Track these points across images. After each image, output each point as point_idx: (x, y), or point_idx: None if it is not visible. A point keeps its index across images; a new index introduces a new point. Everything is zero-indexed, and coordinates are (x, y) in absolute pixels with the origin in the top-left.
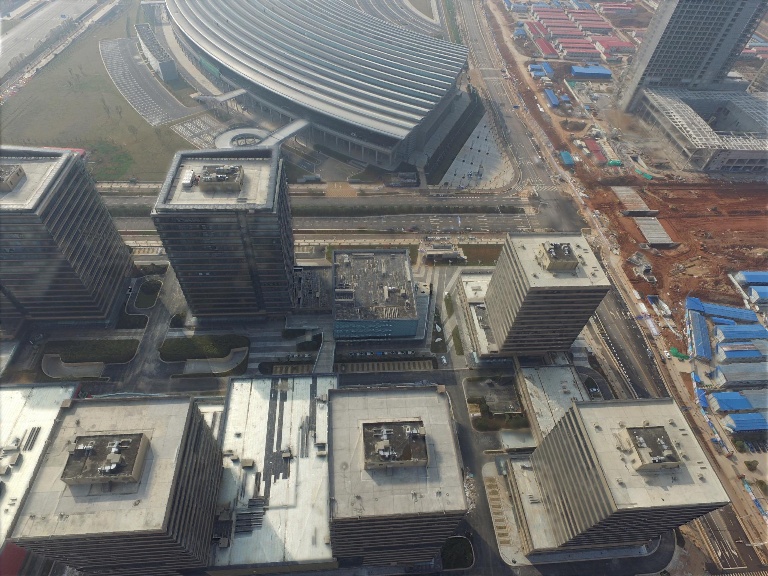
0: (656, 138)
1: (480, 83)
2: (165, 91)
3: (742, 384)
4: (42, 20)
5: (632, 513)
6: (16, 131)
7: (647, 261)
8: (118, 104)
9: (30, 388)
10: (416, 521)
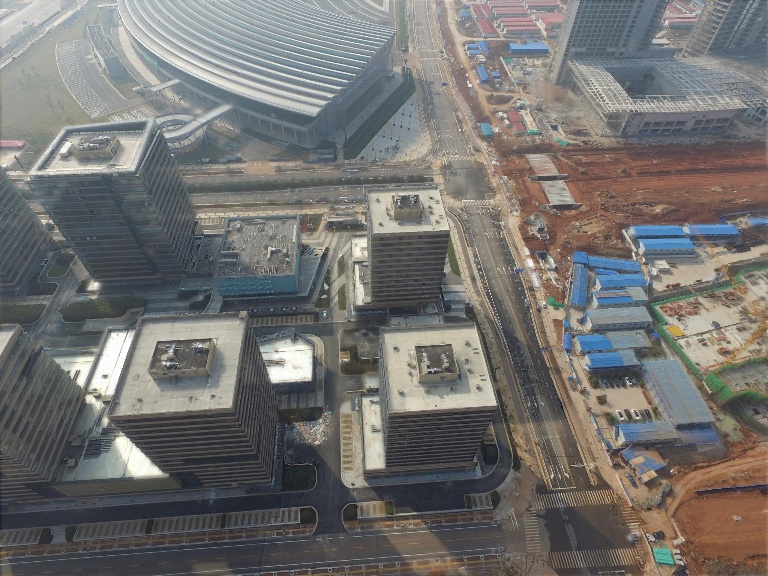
0: (580, 107)
1: (416, 64)
2: (110, 86)
3: (610, 328)
4: (7, 28)
5: (410, 419)
6: None
7: (544, 221)
8: (64, 100)
9: None
10: (196, 422)
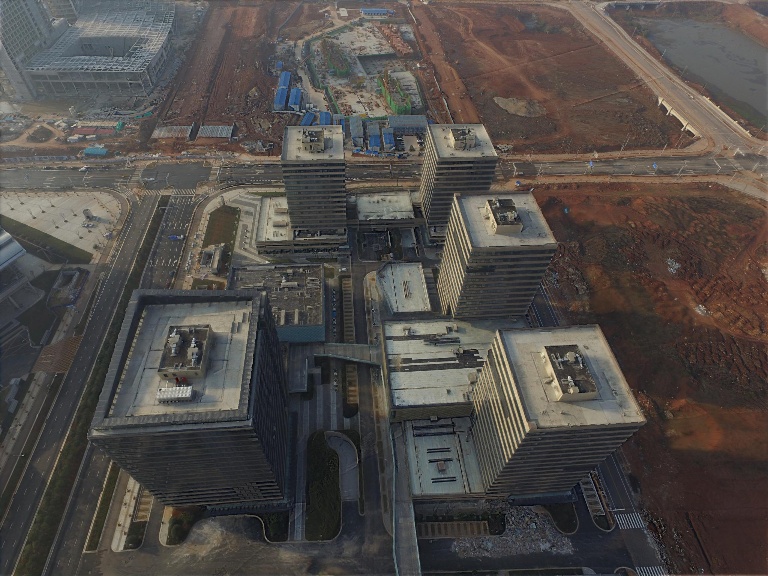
0: (93, 95)
1: None
2: None
3: None
4: None
5: None
6: None
7: (251, 142)
8: None
9: None
10: None
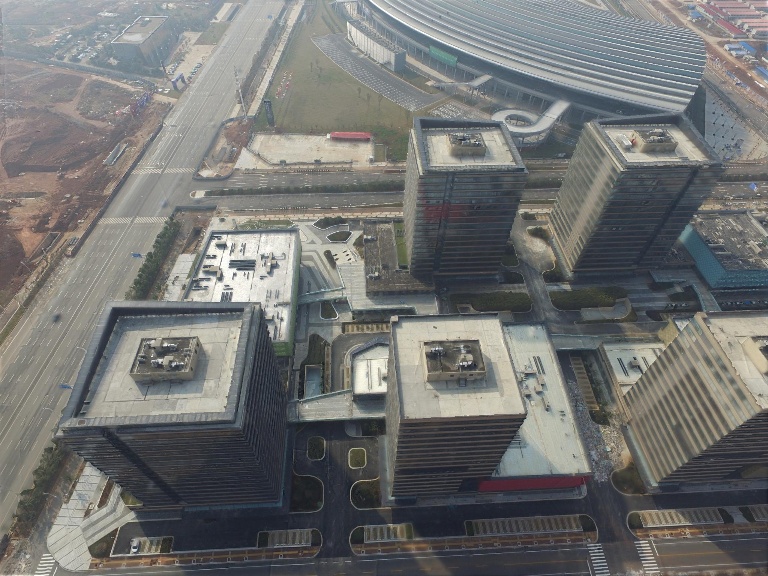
0: None
1: None
2: (401, 80)
3: None
4: (248, 21)
5: None
6: (296, 119)
7: None
8: None
9: (505, 326)
10: None
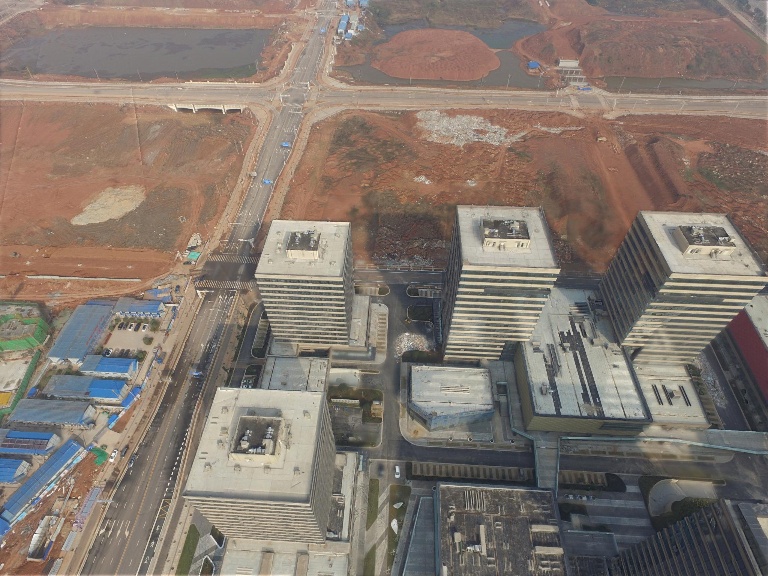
0: None
1: None
2: None
3: None
4: None
5: None
6: None
7: None
8: None
9: None
10: None
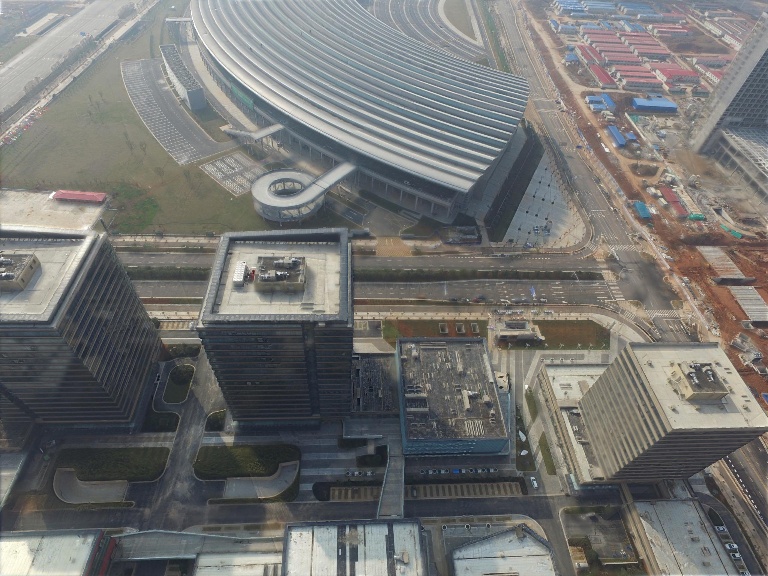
0: (738, 186)
1: (534, 116)
2: (193, 122)
3: None
4: (60, 37)
5: None
6: (30, 169)
7: (754, 346)
8: (142, 138)
9: (39, 537)
10: None
